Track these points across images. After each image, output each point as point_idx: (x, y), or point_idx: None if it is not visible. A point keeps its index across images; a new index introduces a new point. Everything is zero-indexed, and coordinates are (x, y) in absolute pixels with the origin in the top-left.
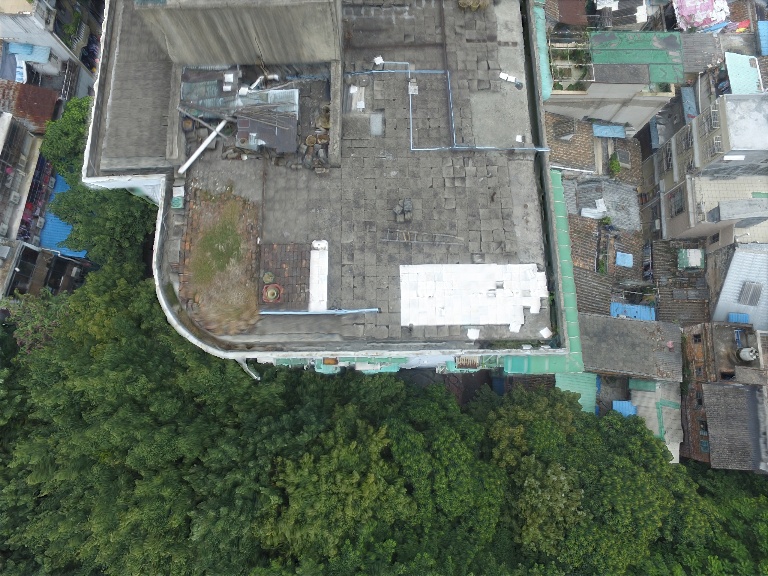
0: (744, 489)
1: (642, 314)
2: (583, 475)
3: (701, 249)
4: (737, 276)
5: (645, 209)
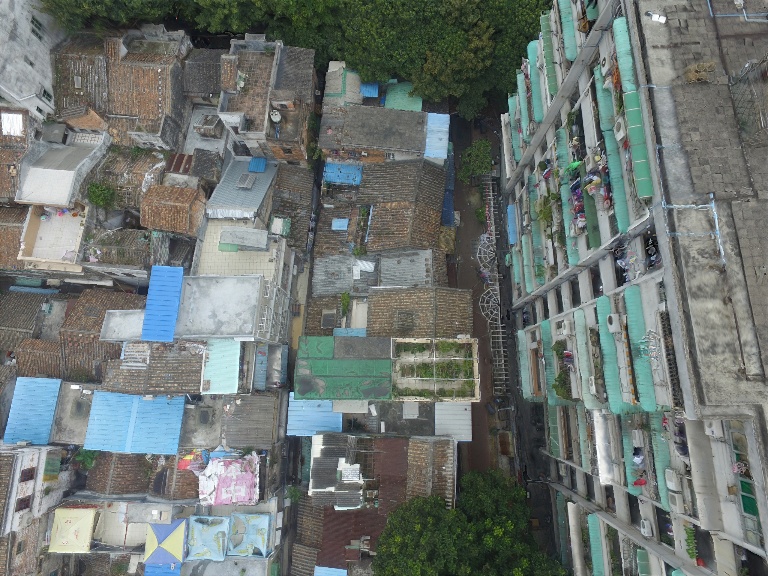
0: (289, 43)
1: (334, 174)
2: (436, 8)
3: (270, 233)
4: (256, 194)
5: (294, 299)
